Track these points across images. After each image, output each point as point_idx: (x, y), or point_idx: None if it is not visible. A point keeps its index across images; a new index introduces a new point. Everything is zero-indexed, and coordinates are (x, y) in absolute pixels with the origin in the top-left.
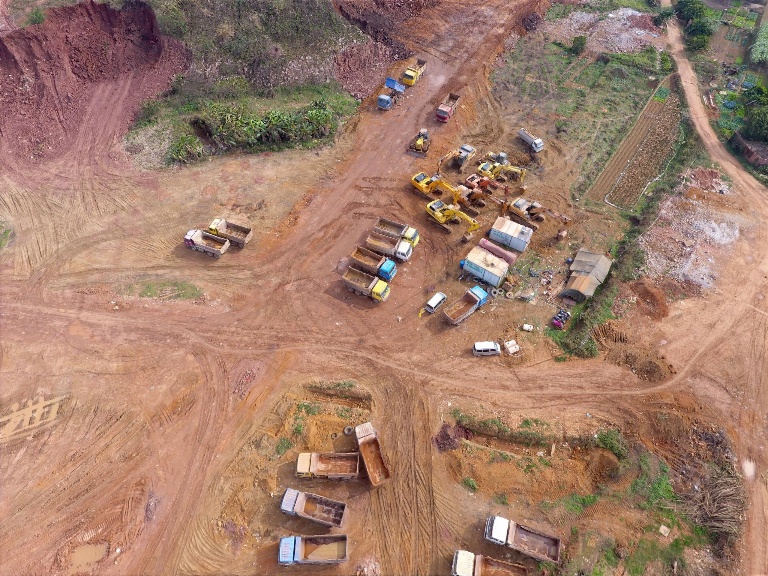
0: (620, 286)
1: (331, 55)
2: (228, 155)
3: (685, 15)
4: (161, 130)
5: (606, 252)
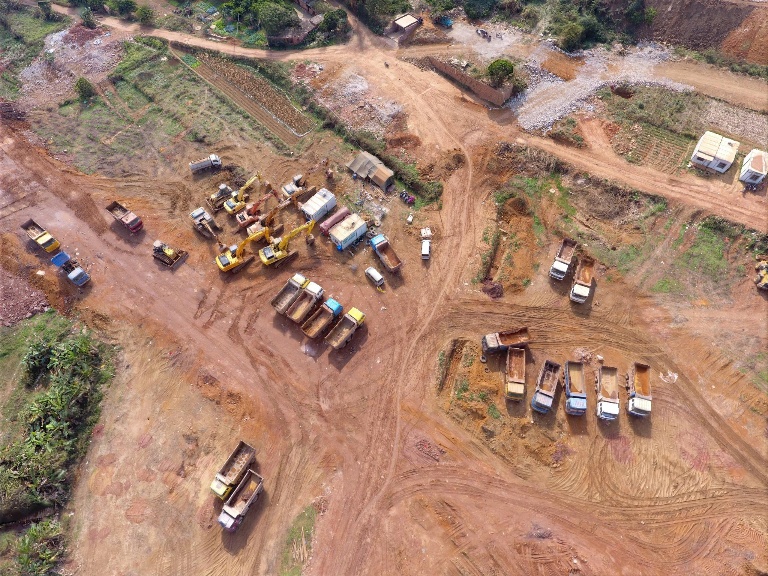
0: (389, 153)
1: None
2: (75, 486)
3: (97, 5)
4: None
5: (351, 153)
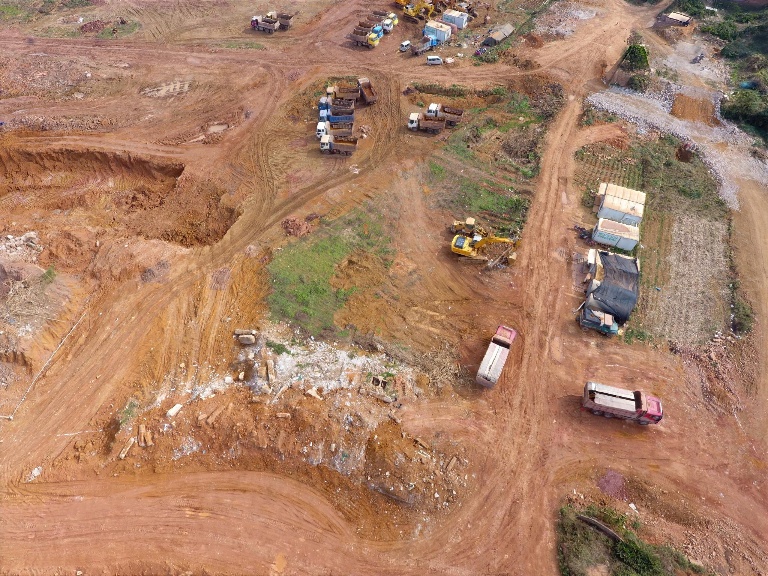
0: None
1: None
2: None
3: None
4: None
5: None
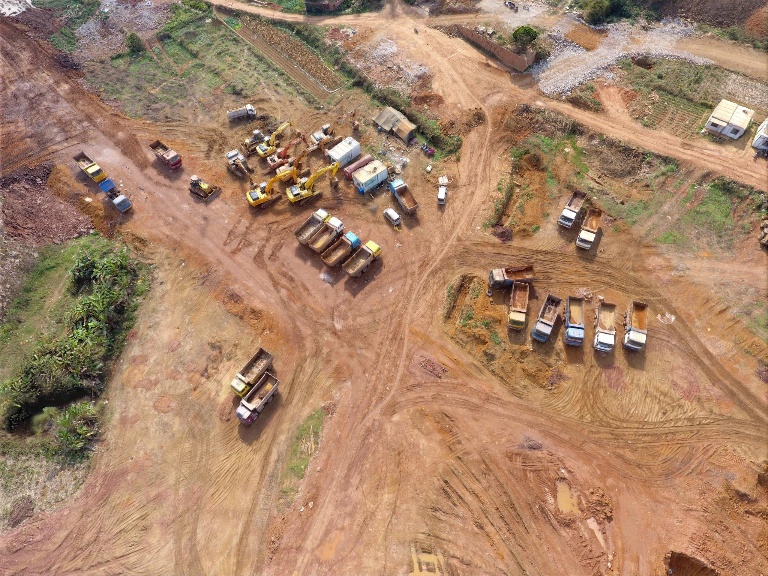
0: (413, 109)
1: (0, 236)
2: (110, 379)
3: None
4: (0, 472)
5: (378, 108)
